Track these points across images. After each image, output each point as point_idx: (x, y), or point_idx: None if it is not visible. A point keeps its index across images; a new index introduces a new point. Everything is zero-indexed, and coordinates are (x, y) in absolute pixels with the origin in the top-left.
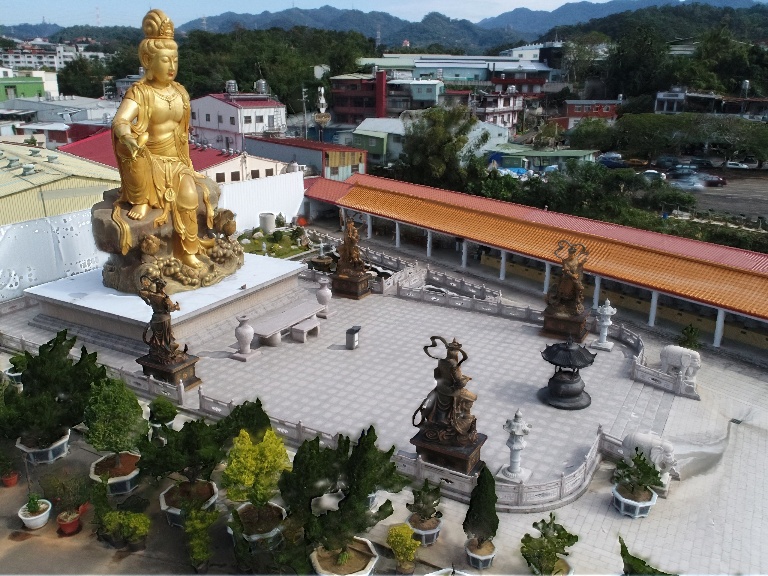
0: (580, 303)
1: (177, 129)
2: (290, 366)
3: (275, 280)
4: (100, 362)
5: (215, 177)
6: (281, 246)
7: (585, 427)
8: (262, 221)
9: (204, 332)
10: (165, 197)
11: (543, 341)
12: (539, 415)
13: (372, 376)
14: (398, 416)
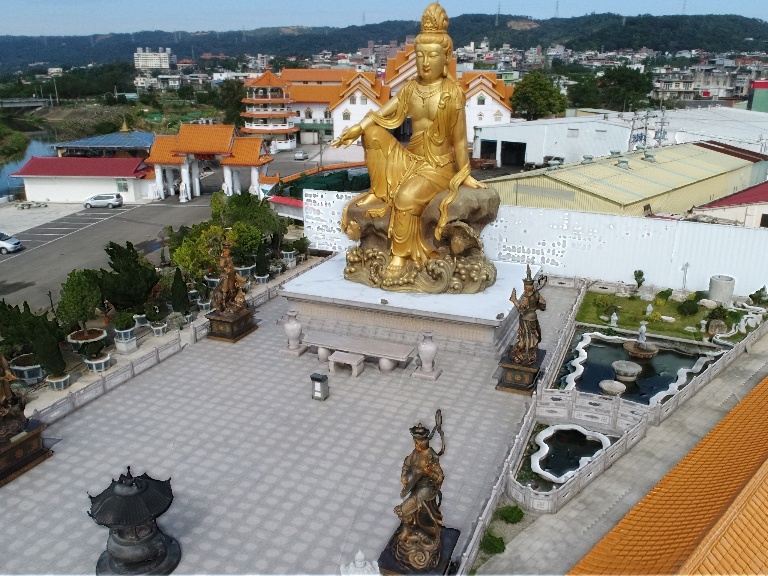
0: (413, 544)
1: (428, 128)
2: (268, 372)
3: (433, 314)
4: (279, 306)
5: (760, 218)
6: (679, 320)
7: (43, 573)
8: (709, 284)
9: (333, 323)
10: (390, 192)
11: (374, 555)
12: (96, 532)
13: (238, 414)
14: (134, 434)
